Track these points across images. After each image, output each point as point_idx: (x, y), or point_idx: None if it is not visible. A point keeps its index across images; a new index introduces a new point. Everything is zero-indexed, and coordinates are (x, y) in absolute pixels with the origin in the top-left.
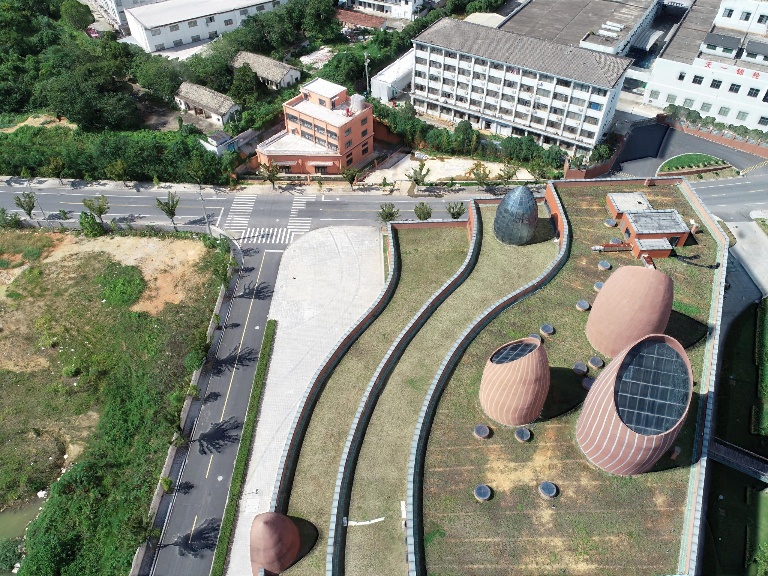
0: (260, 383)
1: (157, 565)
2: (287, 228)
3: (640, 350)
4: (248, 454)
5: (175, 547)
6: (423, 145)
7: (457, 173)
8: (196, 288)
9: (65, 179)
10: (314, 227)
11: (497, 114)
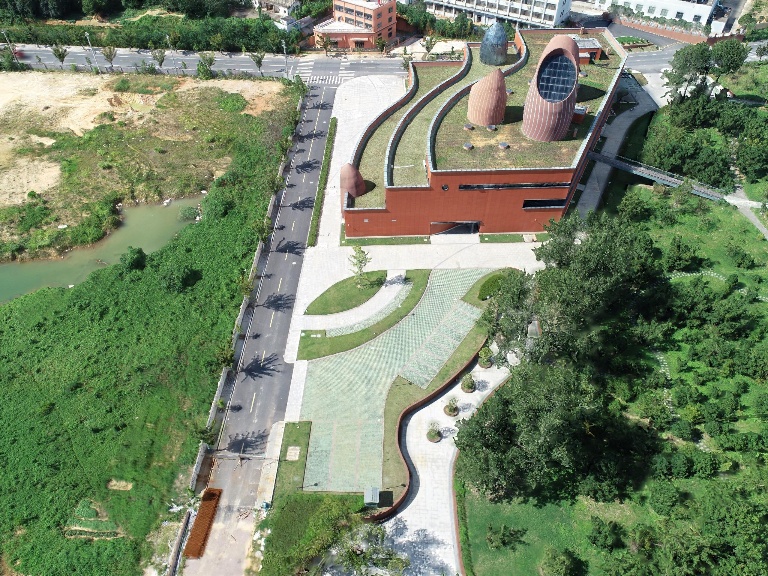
0: (330, 144)
1: (281, 213)
2: (338, 76)
3: (551, 60)
4: (327, 173)
5: (290, 207)
6: (432, 32)
7: (456, 49)
8: (281, 104)
9: (178, 50)
10: (357, 76)
11: (485, 8)
